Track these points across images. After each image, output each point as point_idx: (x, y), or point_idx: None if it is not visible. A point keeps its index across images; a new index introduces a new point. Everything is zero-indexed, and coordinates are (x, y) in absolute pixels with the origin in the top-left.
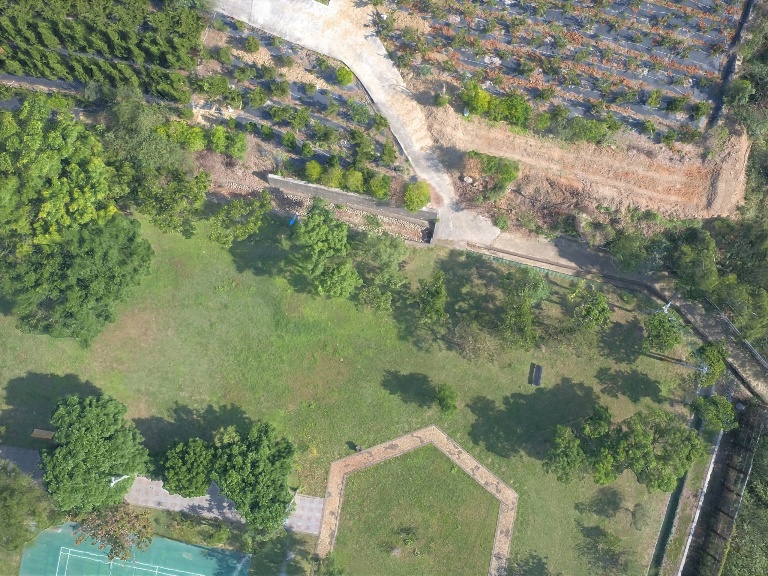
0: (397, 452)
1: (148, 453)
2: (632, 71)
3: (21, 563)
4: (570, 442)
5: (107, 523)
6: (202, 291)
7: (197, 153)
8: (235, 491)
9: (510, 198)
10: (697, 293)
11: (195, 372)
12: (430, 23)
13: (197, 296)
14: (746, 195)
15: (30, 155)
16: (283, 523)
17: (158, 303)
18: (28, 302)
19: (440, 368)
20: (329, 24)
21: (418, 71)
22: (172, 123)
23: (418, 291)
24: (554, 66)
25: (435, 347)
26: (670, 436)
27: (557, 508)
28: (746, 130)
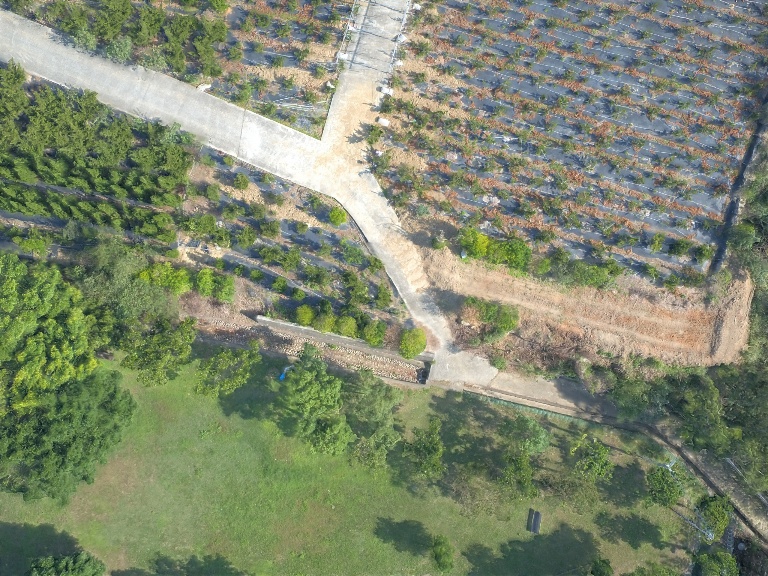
0: None
1: None
2: (634, 213)
3: None
4: None
5: None
6: (186, 435)
7: None
8: None
9: (508, 340)
10: (701, 446)
11: (179, 521)
12: (426, 160)
13: (181, 440)
14: (750, 341)
15: (4, 320)
16: None
17: (140, 448)
18: (0, 467)
19: (436, 515)
20: (321, 159)
21: (414, 210)
22: (156, 265)
23: (413, 435)
24: (554, 207)
25: (431, 493)
26: None
27: None
28: (750, 275)
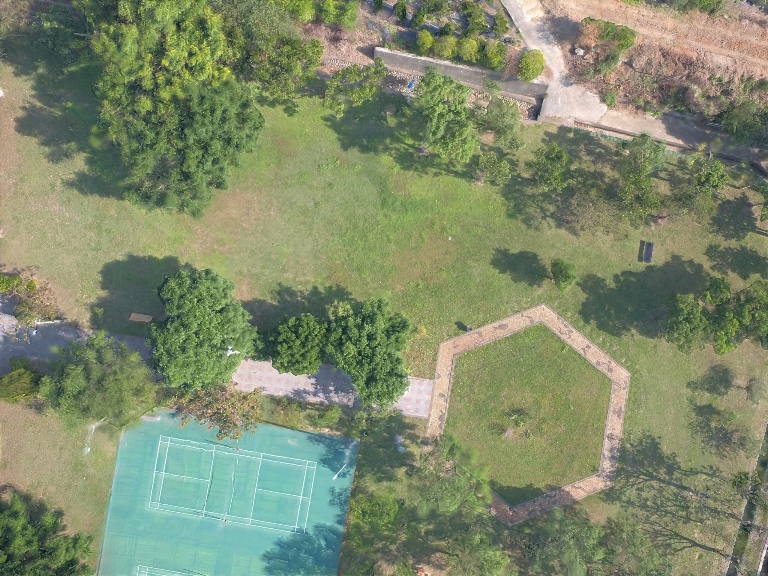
0: (507, 332)
1: (257, 330)
2: None
3: (118, 453)
4: (693, 308)
5: (218, 400)
6: (305, 169)
7: (300, 27)
8: (352, 364)
9: (620, 72)
10: None
11: (299, 252)
12: None
13: (300, 174)
14: None
15: (151, 2)
16: None
17: (260, 182)
18: None
19: (549, 246)
20: None
21: None
22: None
23: None
24: None
25: (544, 225)
26: None
27: (669, 387)
28: None
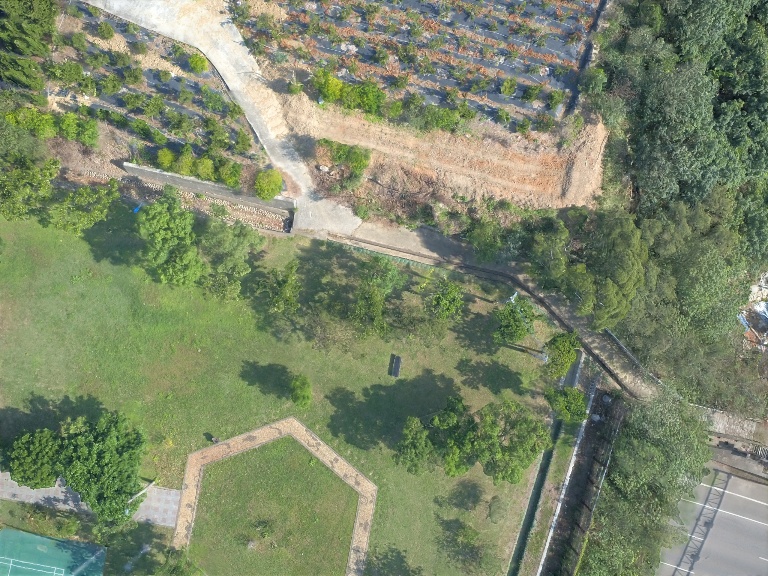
0: (255, 444)
1: None
2: (488, 59)
3: None
4: (417, 433)
5: None
6: (59, 280)
7: (53, 141)
8: (79, 482)
9: (368, 187)
10: (549, 283)
11: (51, 362)
12: (287, 10)
13: (54, 285)
14: (603, 185)
15: None
16: (138, 515)
17: (14, 292)
18: None
19: (299, 359)
20: (185, 11)
21: (274, 58)
22: (22, 110)
23: None
24: (410, 54)
25: (294, 338)
26: (516, 427)
27: (416, 501)
28: (602, 119)
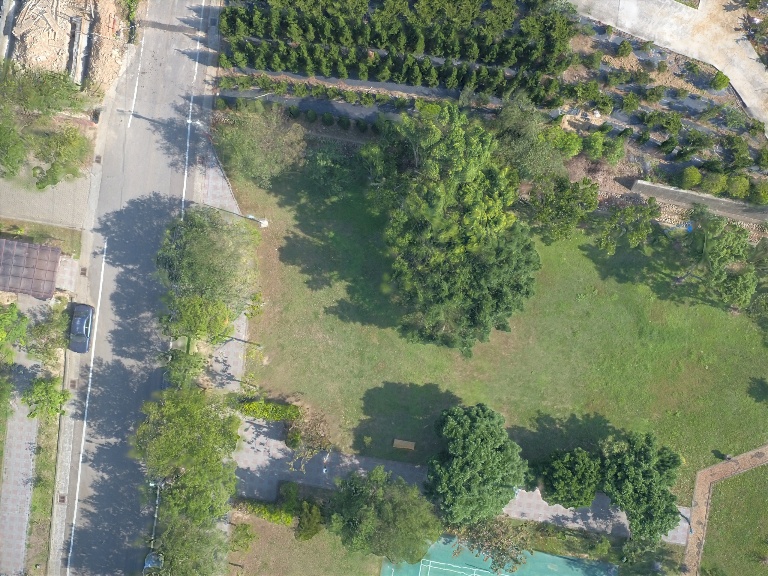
0: (763, 460)
1: (527, 463)
2: None
3: (380, 575)
4: None
5: (495, 535)
6: (563, 299)
7: None
8: (629, 502)
9: None
10: None
11: (557, 381)
12: None
13: (559, 304)
14: None
15: (462, 163)
16: None
17: (519, 311)
18: (436, 311)
19: None
20: (699, 28)
21: None
22: (550, 129)
23: None
24: None
25: None
26: None
27: None
28: None
